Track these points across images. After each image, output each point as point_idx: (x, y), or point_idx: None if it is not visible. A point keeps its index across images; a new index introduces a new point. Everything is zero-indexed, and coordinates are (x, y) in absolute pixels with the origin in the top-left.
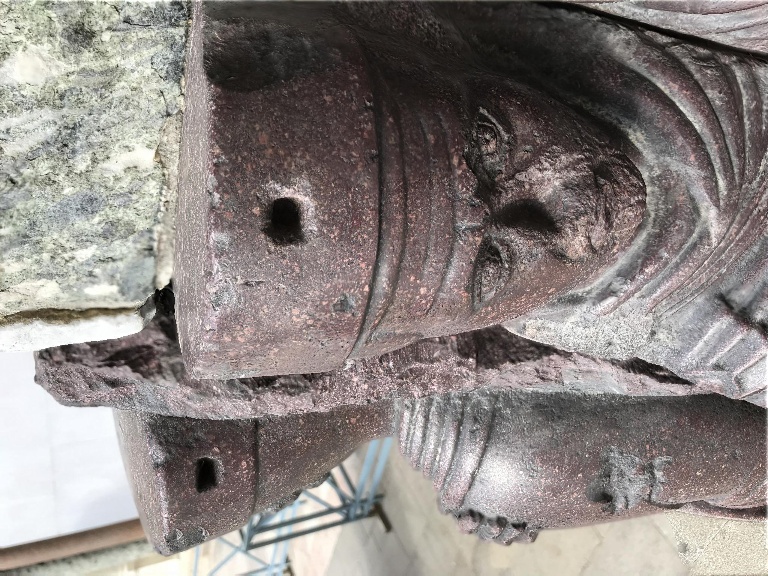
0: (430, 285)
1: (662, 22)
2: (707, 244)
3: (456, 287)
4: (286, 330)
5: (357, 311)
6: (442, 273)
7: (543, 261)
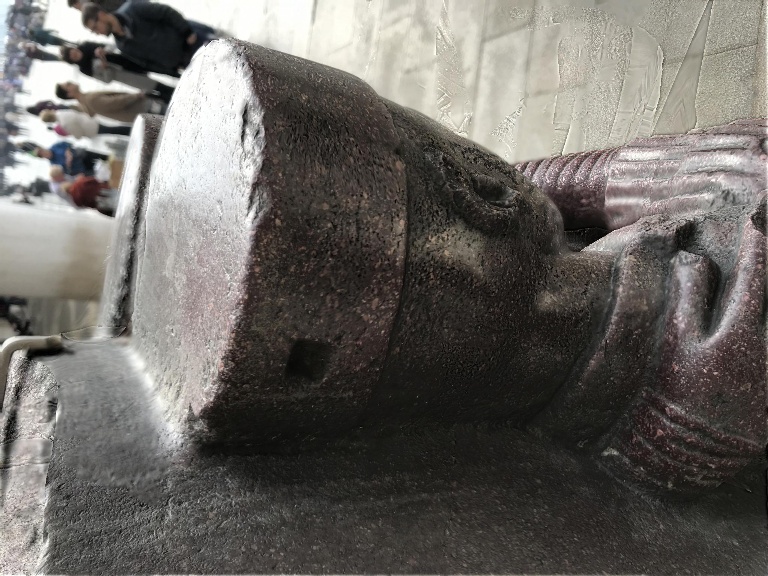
0: None
1: None
2: None
3: None
4: None
5: None
6: None
7: None
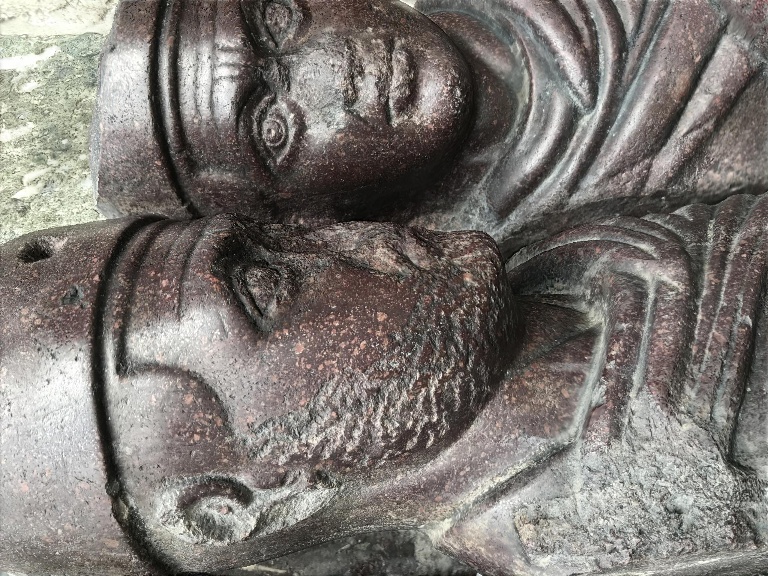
0: (172, 276)
1: (524, 216)
2: (668, 290)
3: (200, 272)
4: (14, 336)
5: (86, 302)
6: (183, 262)
7: (335, 269)
